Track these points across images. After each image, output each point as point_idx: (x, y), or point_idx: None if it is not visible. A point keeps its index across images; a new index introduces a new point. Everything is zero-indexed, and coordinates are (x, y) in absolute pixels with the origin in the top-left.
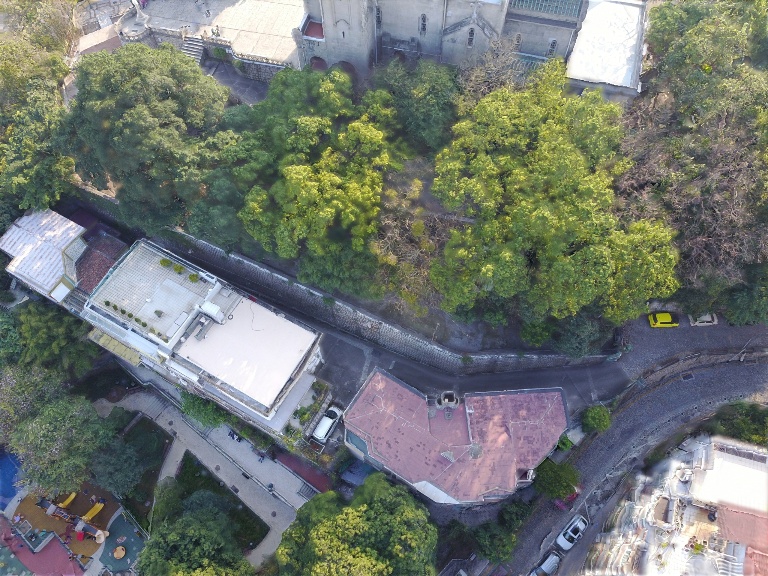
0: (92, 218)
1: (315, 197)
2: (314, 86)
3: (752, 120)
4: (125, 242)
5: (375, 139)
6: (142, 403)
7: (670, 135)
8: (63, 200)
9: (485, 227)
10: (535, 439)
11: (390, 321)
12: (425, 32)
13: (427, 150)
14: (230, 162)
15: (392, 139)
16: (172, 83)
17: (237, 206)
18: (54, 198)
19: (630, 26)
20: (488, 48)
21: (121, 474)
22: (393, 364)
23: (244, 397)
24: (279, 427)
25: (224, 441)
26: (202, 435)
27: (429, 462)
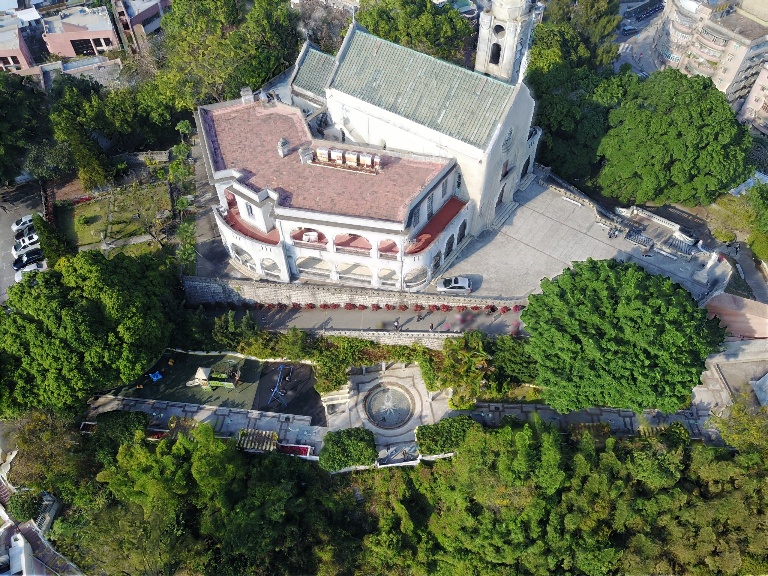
0: None
1: None
2: None
3: None
4: None
5: None
6: None
7: None
8: None
9: None
10: None
11: None
12: None
13: None
14: None
15: None
16: None
17: None
18: None
19: None
20: None
21: None
22: None
23: None
24: None
25: None
26: None
27: None
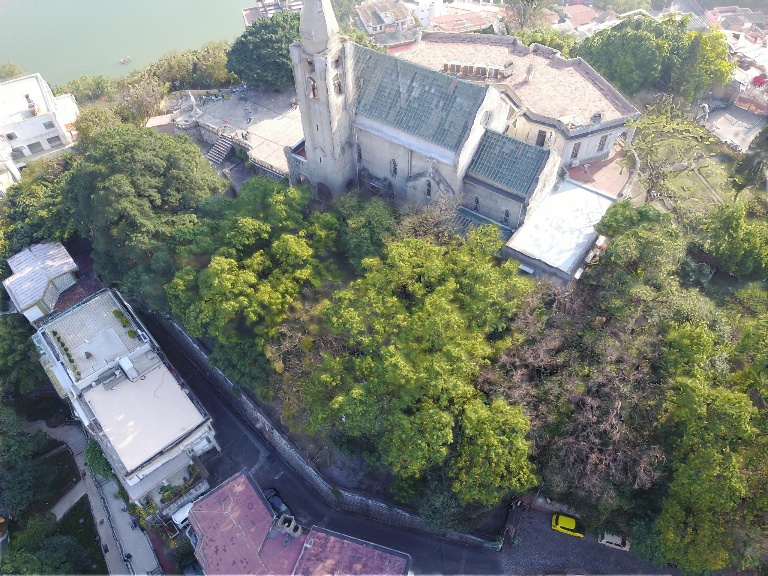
0: None
1: (226, 289)
2: (268, 195)
3: (664, 334)
4: (110, 288)
5: (299, 253)
6: (72, 436)
7: (605, 330)
8: (78, 240)
9: (356, 360)
10: None
11: (280, 429)
12: (396, 175)
13: (361, 278)
14: (177, 240)
15: (323, 258)
16: (162, 165)
17: (169, 279)
18: (67, 236)
19: (595, 216)
20: None
21: (9, 493)
22: (280, 475)
23: (115, 454)
24: (136, 495)
25: (113, 496)
26: (96, 483)
27: None
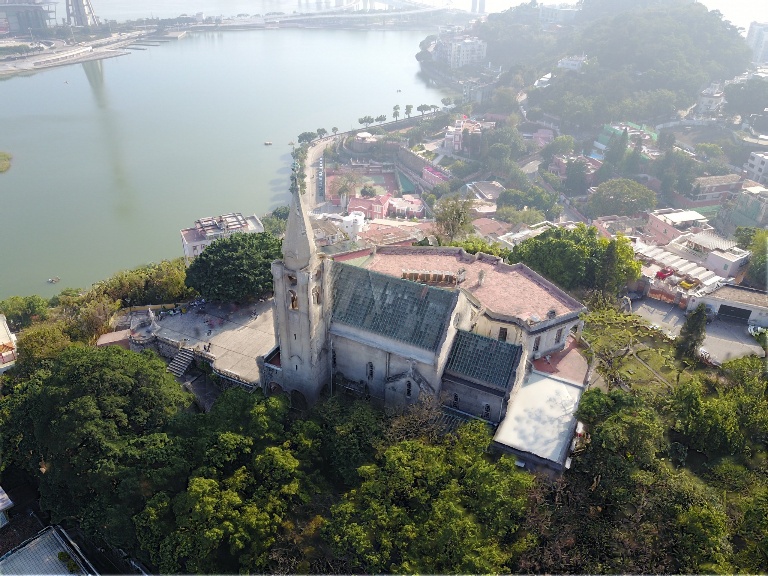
0: (31, 495)
1: (209, 514)
2: (248, 407)
3: (672, 519)
4: None
5: (287, 466)
6: None
7: (604, 520)
8: (13, 471)
9: None
10: None
11: None
12: (372, 377)
13: (348, 488)
14: (148, 463)
15: (310, 470)
16: (130, 383)
17: (137, 509)
18: None
19: (568, 404)
20: (418, 401)
21: None
22: None
23: None
24: None
25: None
26: None
27: None
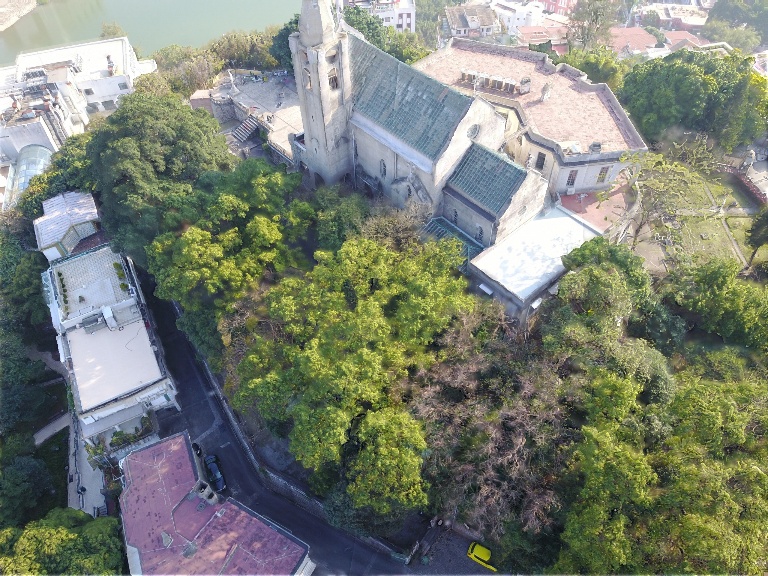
0: None
1: (193, 259)
2: (254, 177)
3: (593, 380)
4: None
5: (267, 236)
6: None
7: None
8: None
9: (286, 347)
10: (246, 575)
11: None
12: (385, 176)
13: None
14: (167, 206)
15: (293, 245)
16: (172, 134)
17: None
18: None
19: (574, 247)
20: None
21: None
22: (226, 444)
23: (77, 393)
24: (87, 434)
25: None
26: (73, 417)
27: (152, 534)
